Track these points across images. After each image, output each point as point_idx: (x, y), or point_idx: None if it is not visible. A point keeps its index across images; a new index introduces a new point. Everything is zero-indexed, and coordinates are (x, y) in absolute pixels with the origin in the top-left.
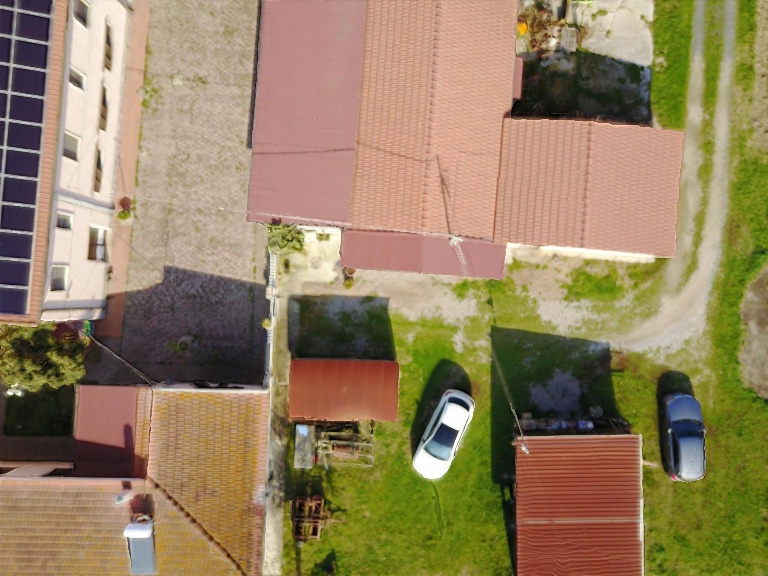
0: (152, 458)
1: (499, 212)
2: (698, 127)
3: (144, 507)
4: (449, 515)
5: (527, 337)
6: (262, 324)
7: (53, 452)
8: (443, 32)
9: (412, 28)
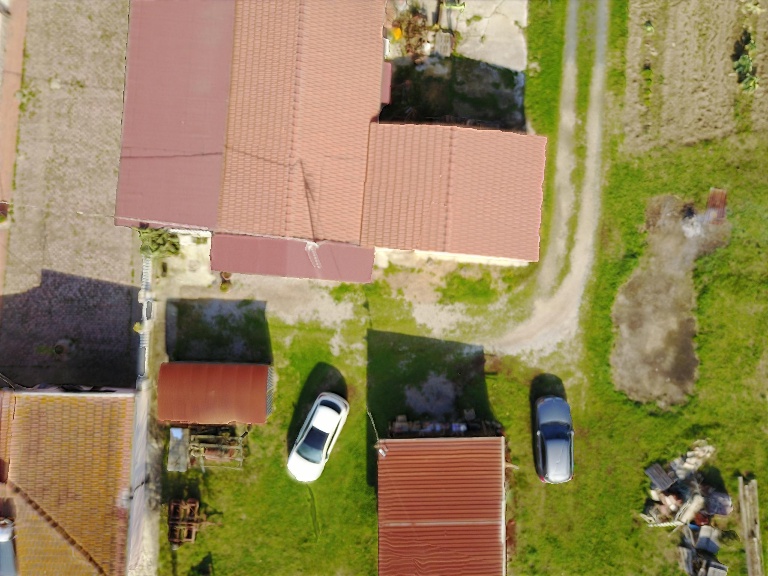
0: (13, 462)
1: (365, 216)
2: (571, 132)
3: (5, 511)
4: (324, 517)
5: (402, 340)
6: (133, 328)
7: None
8: (307, 37)
9: (277, 33)
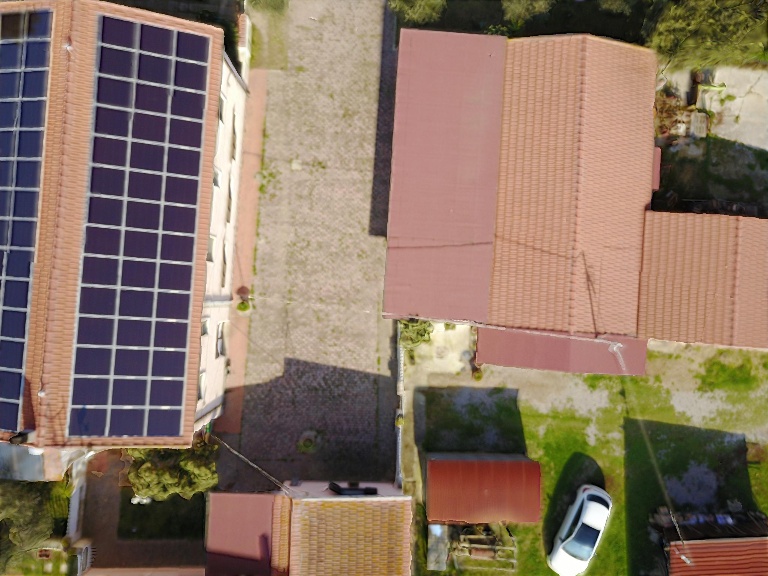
0: (294, 573)
1: (642, 307)
2: None
3: None
4: None
5: (661, 428)
6: (395, 422)
7: (170, 557)
8: (587, 125)
9: (553, 120)
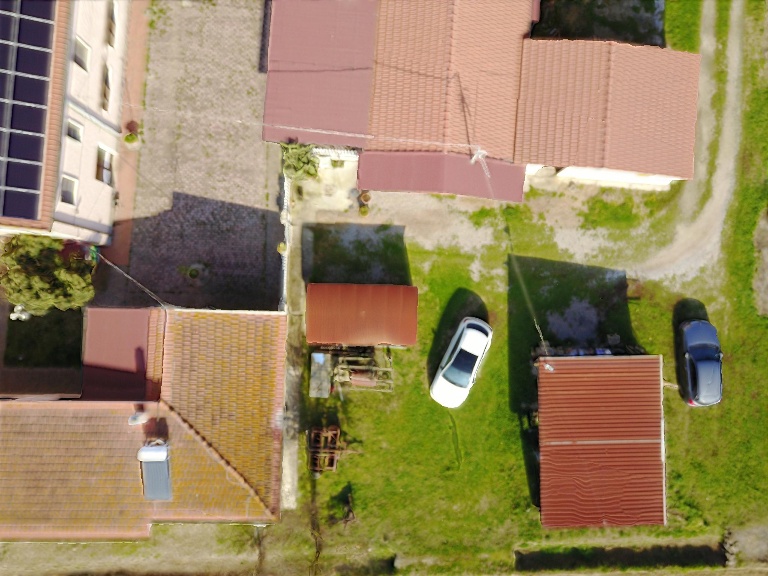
0: (166, 380)
1: (519, 133)
2: (712, 56)
3: (157, 431)
4: (467, 445)
5: (544, 265)
6: (277, 248)
7: (56, 385)
8: None
9: None
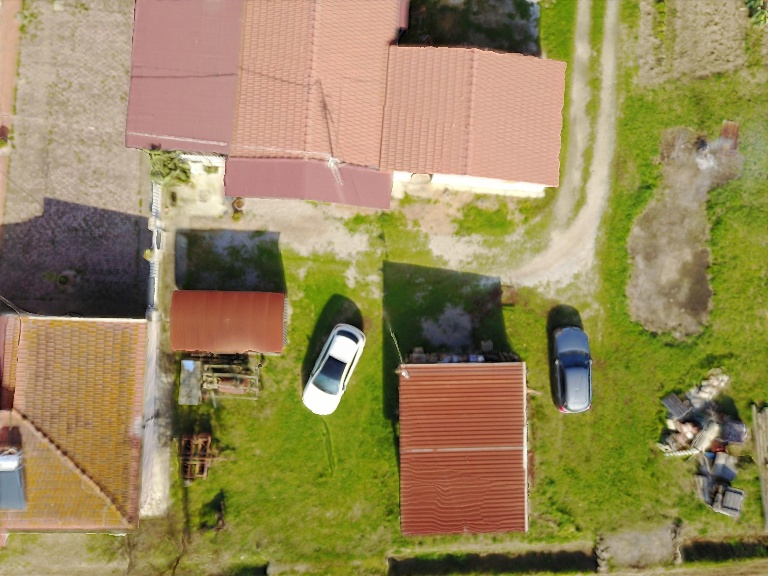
0: (19, 389)
1: (385, 140)
2: (586, 63)
3: (10, 441)
4: (340, 452)
5: (419, 272)
6: (143, 255)
7: None
8: None
9: None
